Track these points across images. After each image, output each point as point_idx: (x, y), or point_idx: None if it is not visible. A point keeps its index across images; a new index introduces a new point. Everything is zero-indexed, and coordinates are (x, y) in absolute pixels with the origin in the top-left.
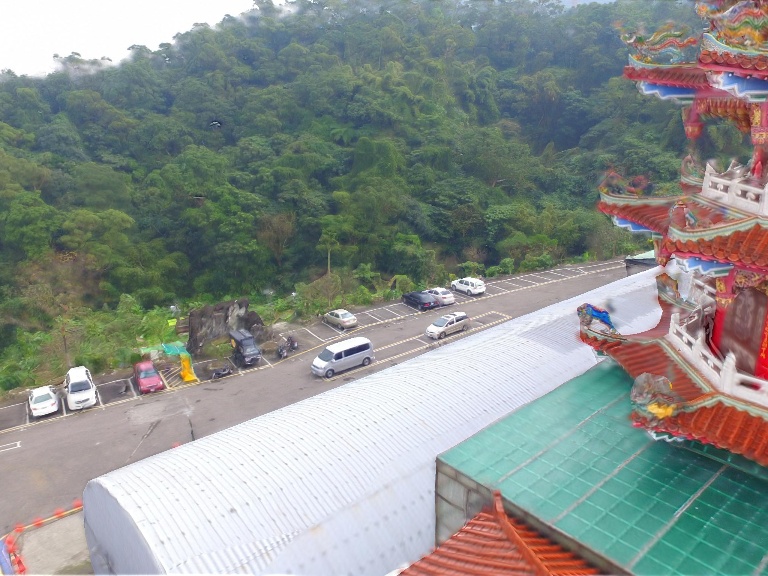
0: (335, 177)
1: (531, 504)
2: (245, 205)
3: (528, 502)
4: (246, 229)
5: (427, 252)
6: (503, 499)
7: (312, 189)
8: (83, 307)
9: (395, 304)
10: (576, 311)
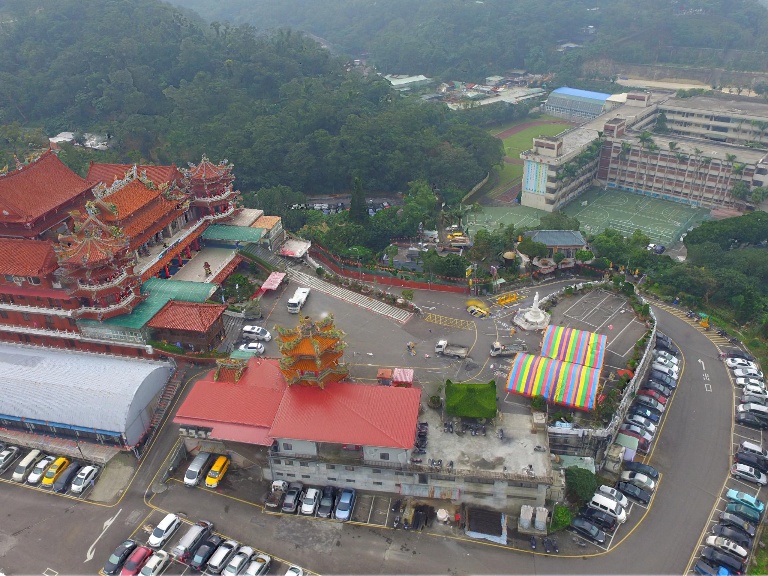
0: None
1: (148, 320)
2: None
3: (147, 320)
4: None
5: None
6: (148, 322)
7: None
8: None
9: None
10: (6, 363)
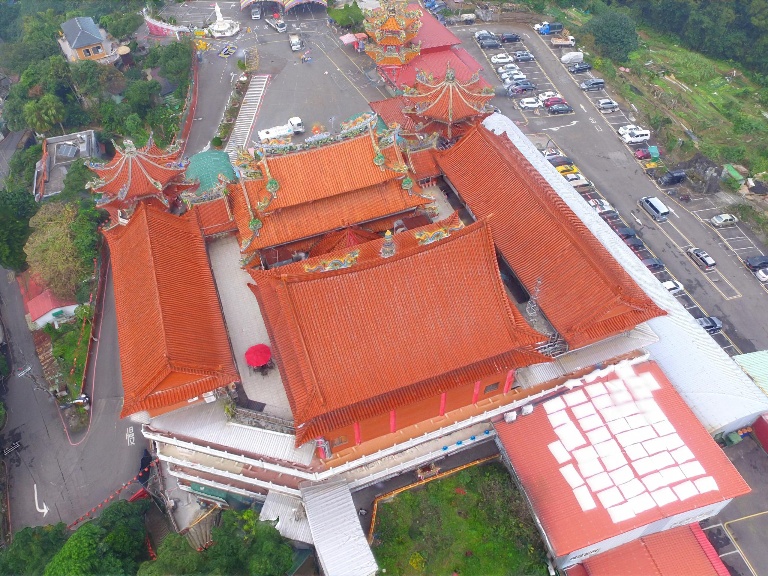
0: None
1: None
2: None
3: None
4: None
5: None
6: None
7: None
8: None
9: (763, 253)
10: None
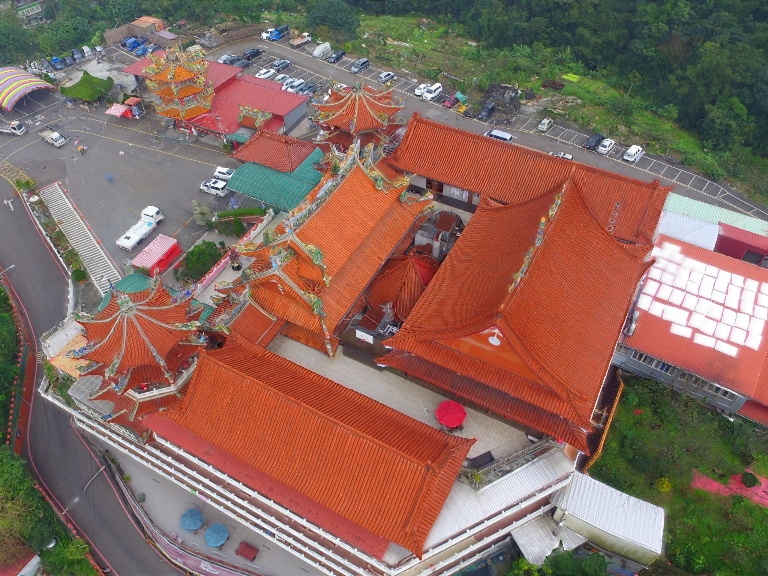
0: (761, 23)
1: None
2: (671, 18)
3: None
4: (657, 37)
5: (728, 123)
6: None
7: (742, 24)
8: (542, 44)
9: (587, 135)
10: None
